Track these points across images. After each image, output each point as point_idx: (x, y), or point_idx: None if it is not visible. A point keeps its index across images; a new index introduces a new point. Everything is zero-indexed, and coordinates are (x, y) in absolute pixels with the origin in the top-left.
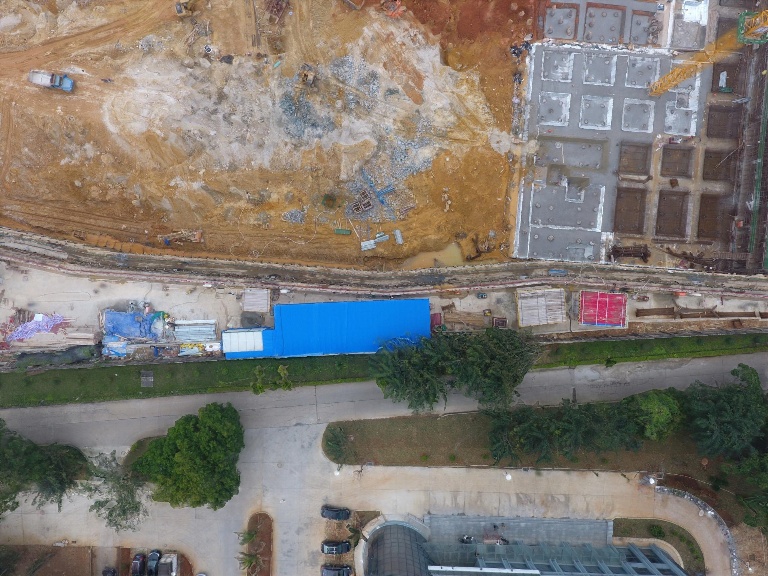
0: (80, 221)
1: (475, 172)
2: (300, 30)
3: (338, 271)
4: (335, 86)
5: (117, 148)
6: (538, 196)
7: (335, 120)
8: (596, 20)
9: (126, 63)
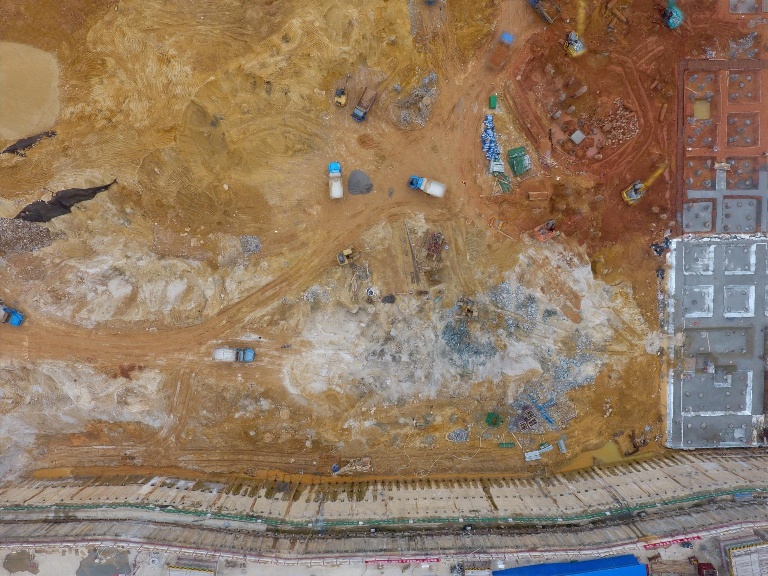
0: (249, 459)
1: (636, 382)
2: (458, 264)
3: (530, 514)
4: (494, 312)
5: (294, 403)
6: (687, 385)
7: (495, 344)
8: (732, 210)
9: (299, 323)
